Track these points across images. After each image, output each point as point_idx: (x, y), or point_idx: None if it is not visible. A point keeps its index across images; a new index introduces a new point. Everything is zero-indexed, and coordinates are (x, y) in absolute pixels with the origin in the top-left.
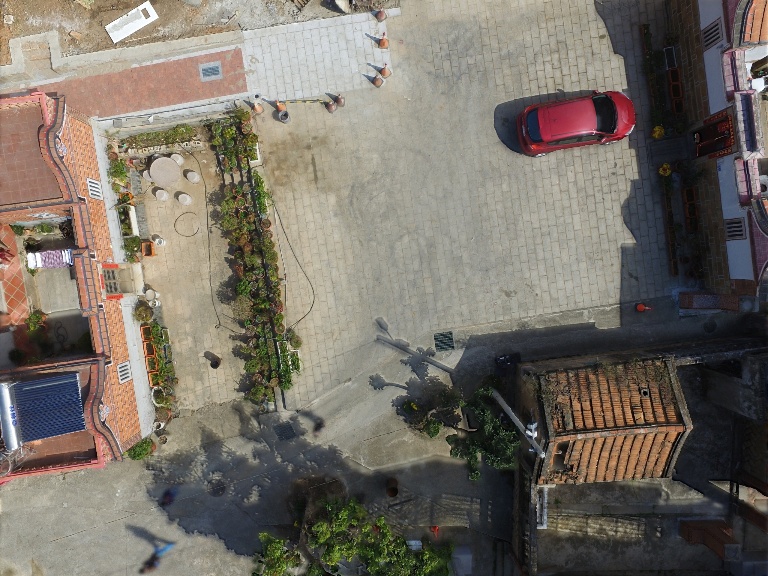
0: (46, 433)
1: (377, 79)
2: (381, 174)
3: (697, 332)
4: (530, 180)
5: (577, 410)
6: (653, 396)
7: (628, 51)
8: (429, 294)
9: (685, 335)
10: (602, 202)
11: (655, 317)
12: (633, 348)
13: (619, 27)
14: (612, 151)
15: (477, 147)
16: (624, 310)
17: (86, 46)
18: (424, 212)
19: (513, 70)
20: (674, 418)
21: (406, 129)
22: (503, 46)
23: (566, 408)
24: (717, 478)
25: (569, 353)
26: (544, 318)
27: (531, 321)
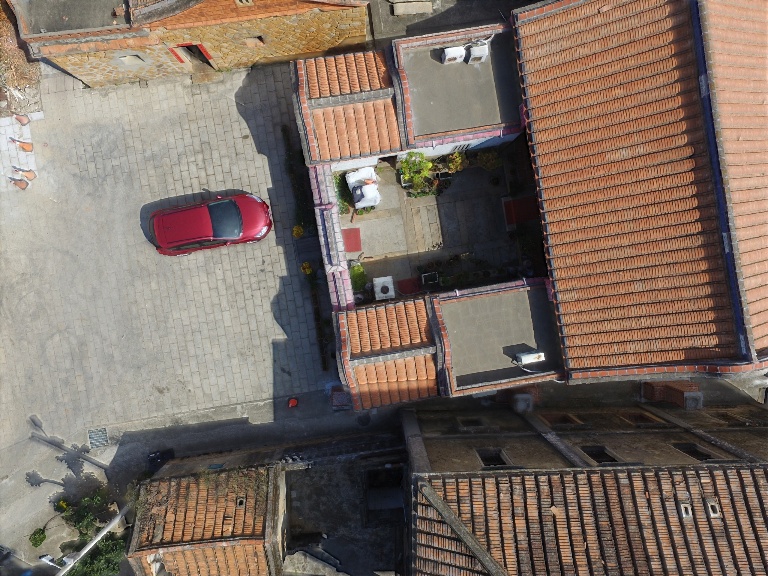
0: None
1: None
2: (30, 274)
3: (351, 426)
4: (179, 278)
5: (169, 521)
6: (247, 506)
7: (271, 151)
8: (82, 391)
9: (339, 429)
10: (251, 299)
11: (308, 411)
12: (286, 443)
13: (261, 127)
14: (259, 249)
15: (124, 246)
16: (277, 405)
17: None
18: (74, 311)
19: (157, 171)
20: (260, 530)
21: (53, 230)
22: (147, 148)
23: (159, 519)
24: (382, 569)
25: (223, 448)
26: (197, 414)
27: (184, 417)
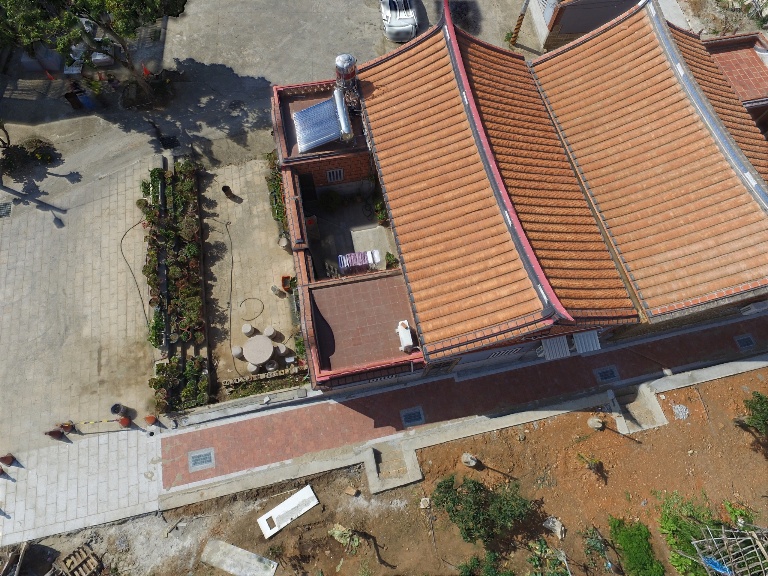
0: (319, 107)
1: (1, 458)
2: (28, 359)
3: None
4: None
5: None
6: None
7: None
8: (6, 250)
9: None
10: None
11: None
12: None
13: None
14: None
15: None
16: None
17: (342, 481)
18: None
19: None
20: None
21: None
22: None
23: None
24: None
25: None
26: None
27: None
